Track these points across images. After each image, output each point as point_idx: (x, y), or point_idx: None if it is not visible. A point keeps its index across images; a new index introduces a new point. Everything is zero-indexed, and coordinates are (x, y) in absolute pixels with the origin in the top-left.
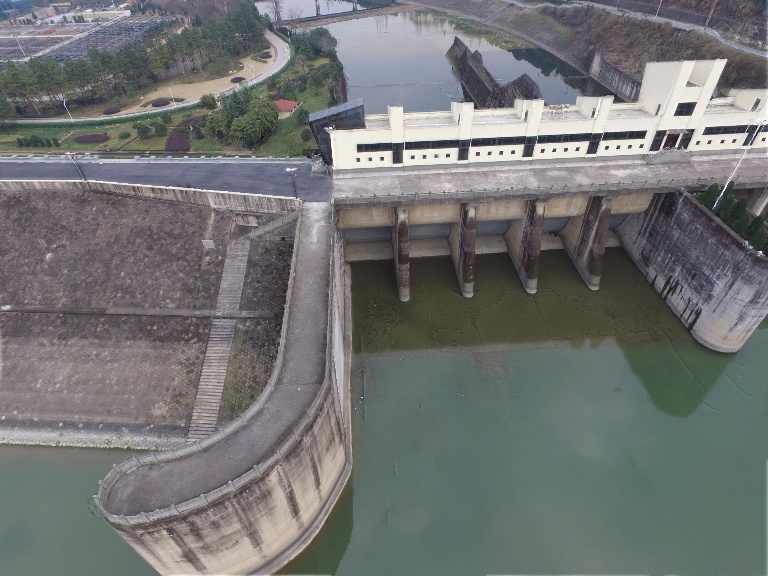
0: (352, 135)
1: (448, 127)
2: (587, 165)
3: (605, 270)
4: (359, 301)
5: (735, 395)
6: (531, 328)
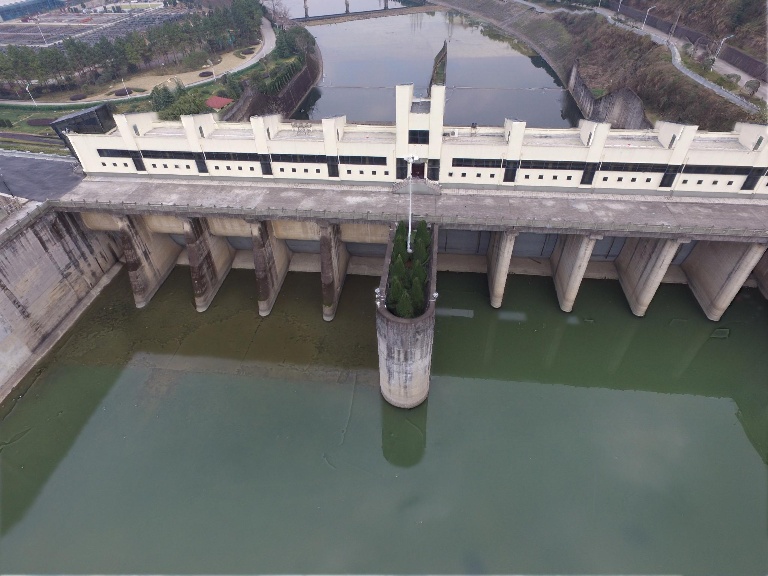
0: (88, 139)
1: (176, 138)
2: (330, 188)
3: (357, 301)
4: (101, 302)
5: (371, 455)
6: (230, 351)
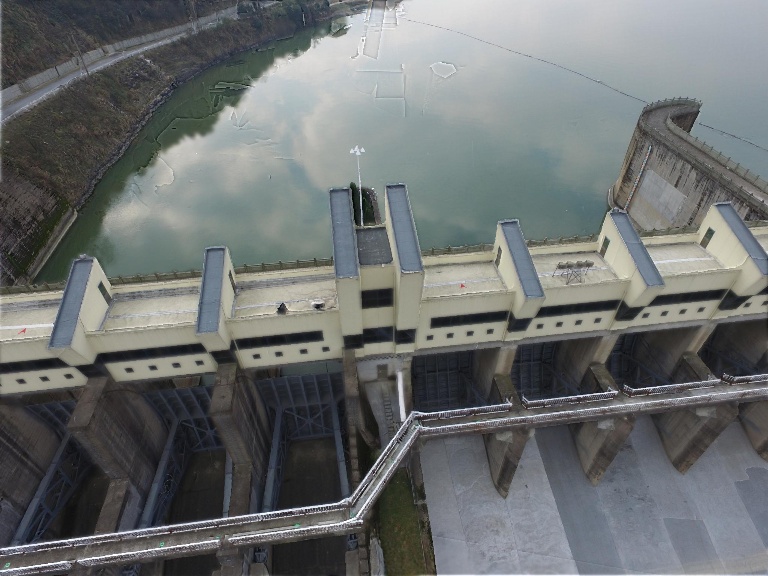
0: None
1: None
2: None
3: None
4: None
5: None
6: None
